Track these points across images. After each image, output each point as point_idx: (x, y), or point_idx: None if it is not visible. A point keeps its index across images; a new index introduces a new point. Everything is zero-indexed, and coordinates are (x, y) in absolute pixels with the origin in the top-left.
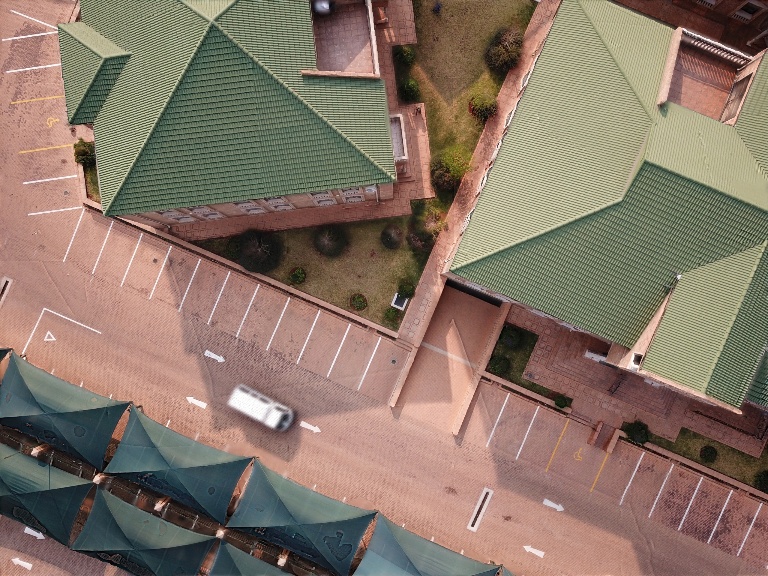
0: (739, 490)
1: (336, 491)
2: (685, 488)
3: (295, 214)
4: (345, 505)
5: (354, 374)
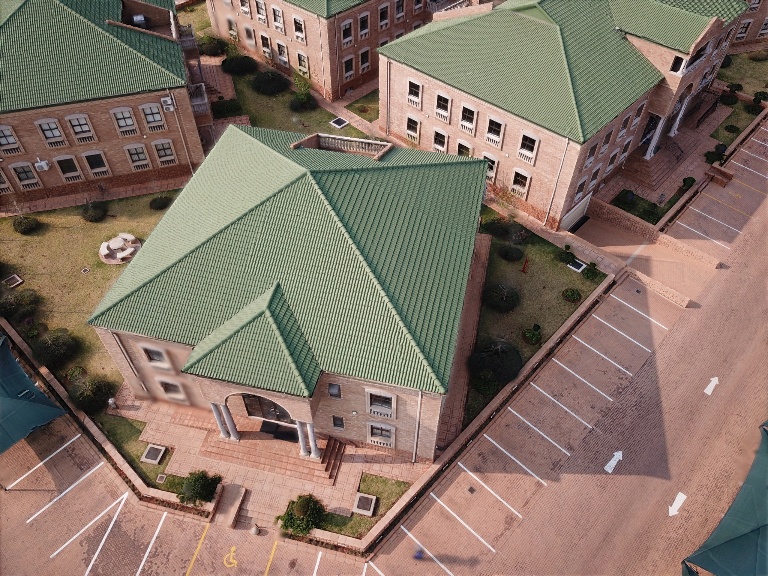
0: (761, 124)
1: None
2: (761, 148)
3: (463, 320)
4: None
5: (649, 327)
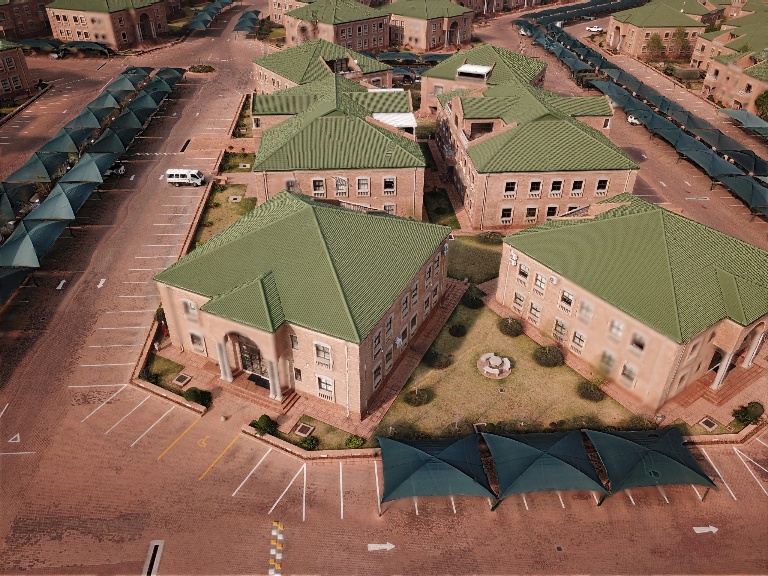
0: None
1: (765, 235)
2: None
3: None
4: (766, 214)
5: None
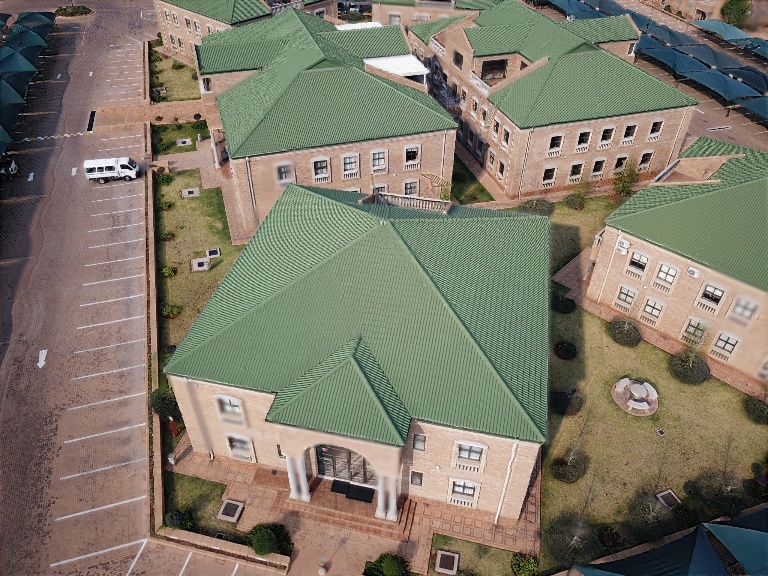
0: None
1: None
2: None
3: None
4: None
5: None
